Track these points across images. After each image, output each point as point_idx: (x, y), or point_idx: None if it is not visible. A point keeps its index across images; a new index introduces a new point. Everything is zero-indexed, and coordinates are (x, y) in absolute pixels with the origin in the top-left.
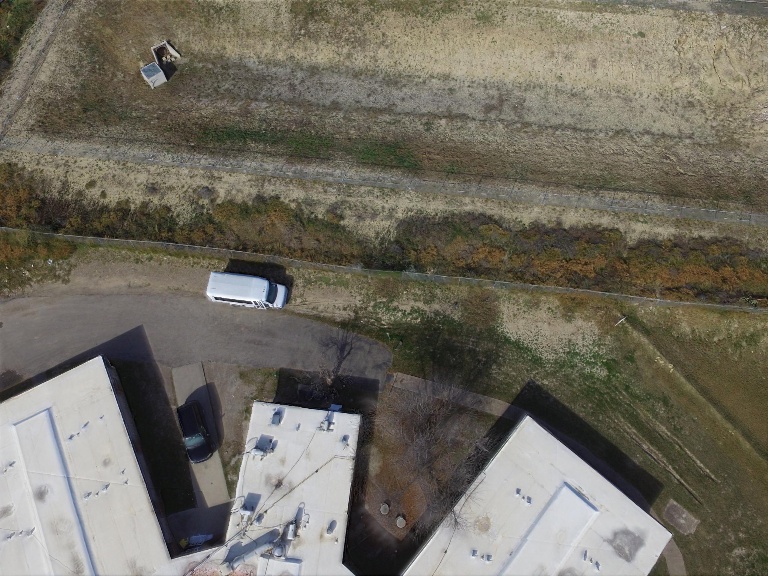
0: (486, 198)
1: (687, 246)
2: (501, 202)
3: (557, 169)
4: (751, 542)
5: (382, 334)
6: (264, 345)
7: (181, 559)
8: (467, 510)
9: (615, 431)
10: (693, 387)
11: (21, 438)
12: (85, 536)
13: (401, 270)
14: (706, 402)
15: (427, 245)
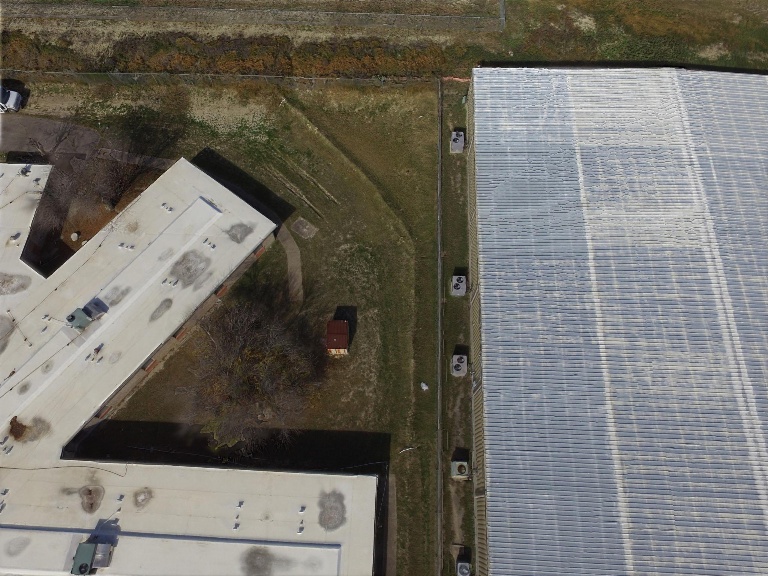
0: (186, 21)
1: (339, 44)
2: (198, 23)
3: (252, 2)
4: (355, 240)
5: (94, 124)
6: None
7: None
8: (122, 219)
9: (266, 176)
10: (329, 141)
11: None
12: None
13: (105, 71)
14: (338, 150)
15: None
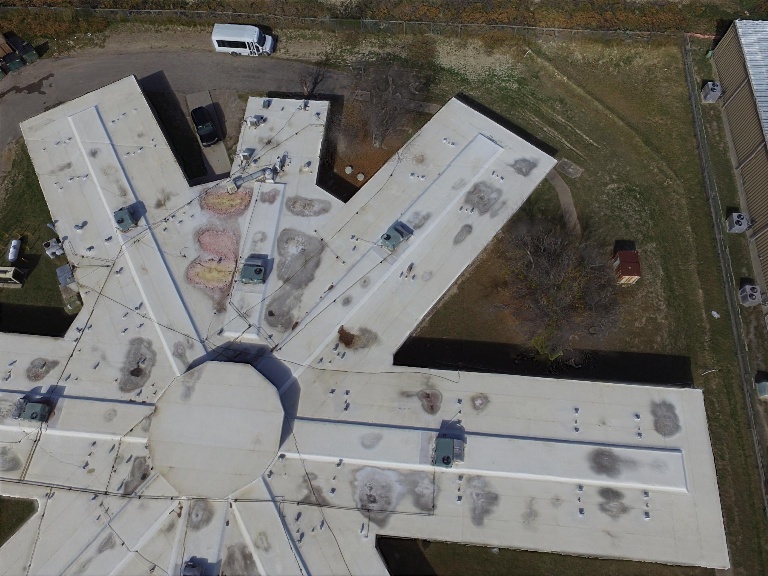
0: None
1: None
2: None
3: None
4: (621, 180)
5: (346, 68)
6: (256, 78)
7: (197, 187)
8: (407, 152)
9: (522, 120)
10: (581, 89)
11: (75, 123)
12: (126, 176)
13: (359, 18)
14: (591, 98)
15: (380, 8)
